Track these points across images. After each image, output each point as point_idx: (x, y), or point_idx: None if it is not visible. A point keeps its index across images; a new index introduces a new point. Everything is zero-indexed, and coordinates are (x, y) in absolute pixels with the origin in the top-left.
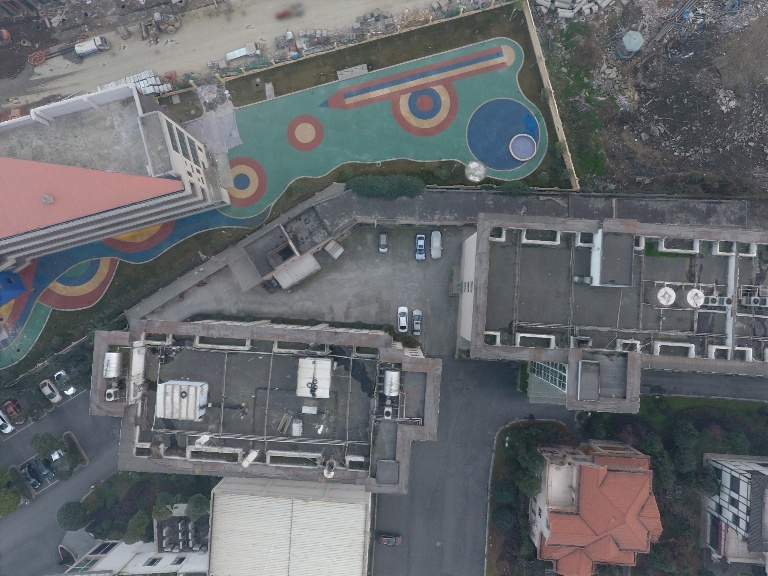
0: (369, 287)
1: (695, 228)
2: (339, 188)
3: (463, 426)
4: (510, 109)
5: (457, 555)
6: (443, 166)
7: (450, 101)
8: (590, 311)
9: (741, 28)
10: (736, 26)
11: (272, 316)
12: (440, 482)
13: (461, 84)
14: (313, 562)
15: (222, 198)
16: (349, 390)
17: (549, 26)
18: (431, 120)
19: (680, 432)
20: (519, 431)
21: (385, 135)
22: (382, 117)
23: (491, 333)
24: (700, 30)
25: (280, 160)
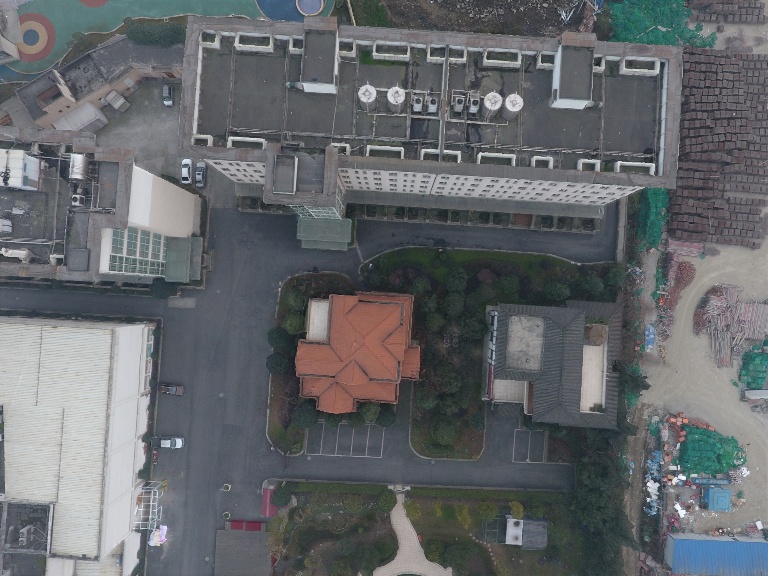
0: (155, 141)
1: (403, 31)
2: None
3: (248, 279)
4: None
5: (240, 406)
6: None
7: None
8: (305, 118)
9: None
10: None
11: None
12: (224, 334)
13: None
14: (61, 388)
15: (2, 47)
16: (57, 190)
17: None
18: None
19: (450, 276)
20: (301, 282)
21: None
22: None
23: (201, 136)
24: None
25: (69, 16)
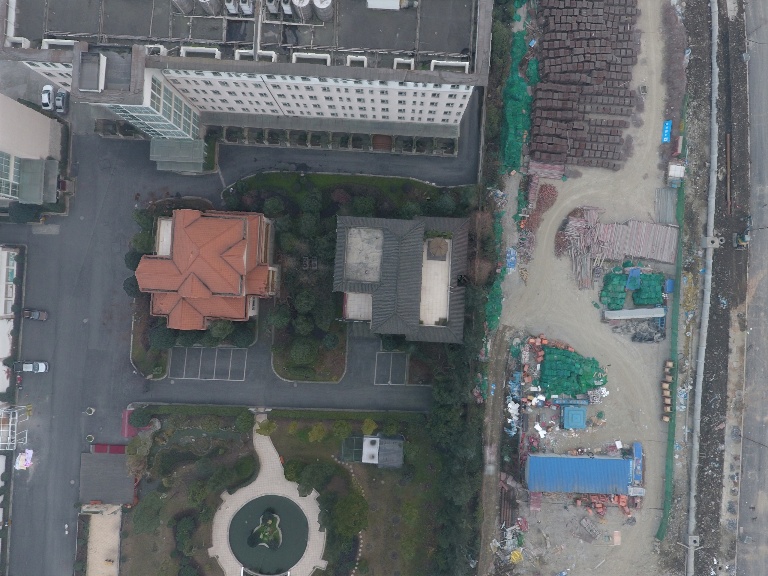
0: (17, 68)
1: None
2: None
3: (111, 205)
4: None
5: (104, 331)
6: None
7: None
8: (123, 21)
9: None
10: None
11: None
12: (88, 260)
13: None
14: None
15: None
16: None
17: None
18: None
19: (304, 197)
20: (162, 207)
21: None
22: None
23: (15, 38)
24: None
25: None
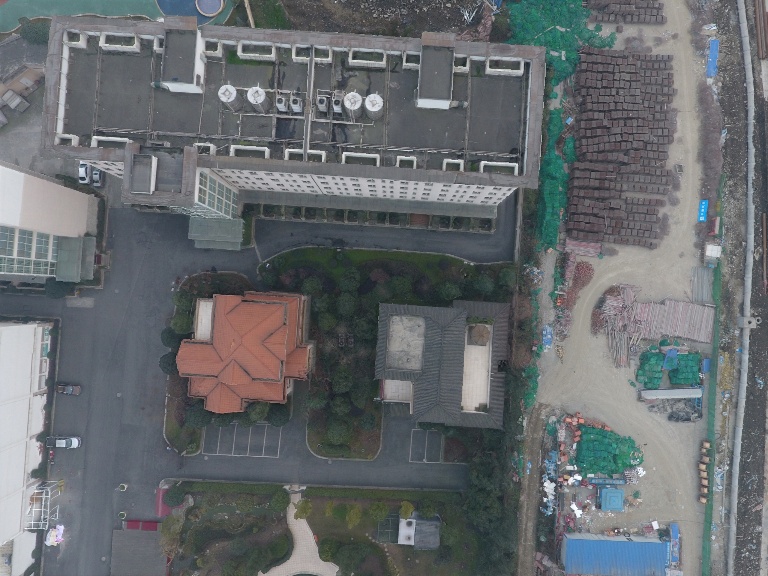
0: None
1: (266, 31)
2: None
3: (146, 278)
4: None
5: (137, 406)
6: None
7: None
8: (172, 118)
9: None
10: None
11: None
12: (122, 334)
13: None
14: None
15: None
16: None
17: None
18: None
19: (343, 276)
20: (198, 282)
21: None
22: None
23: (65, 135)
24: None
25: None
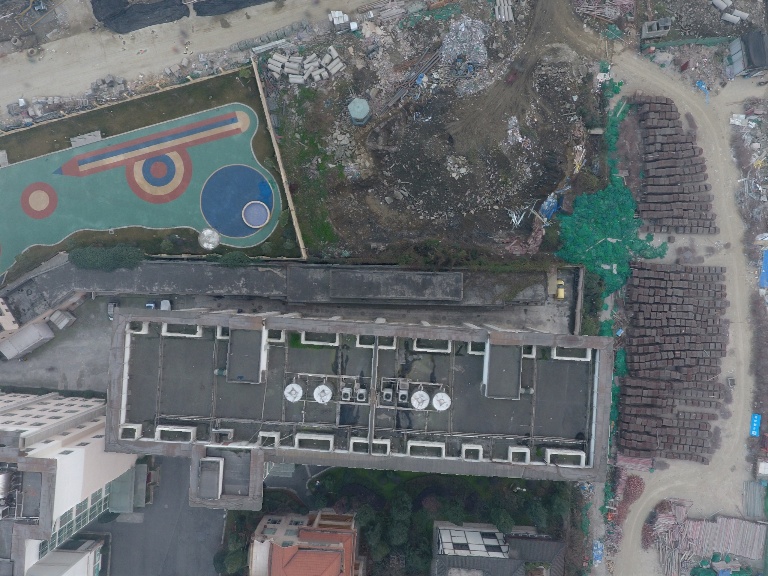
0: (102, 355)
1: (330, 322)
2: (64, 258)
3: None
4: (244, 176)
5: None
6: (172, 235)
7: (184, 168)
8: (235, 403)
9: (476, 93)
10: (470, 91)
11: (5, 384)
12: (172, 549)
13: (195, 150)
14: None
15: None
16: None
17: (284, 91)
18: (165, 187)
19: (395, 504)
20: None
21: (119, 202)
22: (116, 184)
23: (129, 427)
24: (438, 94)
25: (14, 228)
